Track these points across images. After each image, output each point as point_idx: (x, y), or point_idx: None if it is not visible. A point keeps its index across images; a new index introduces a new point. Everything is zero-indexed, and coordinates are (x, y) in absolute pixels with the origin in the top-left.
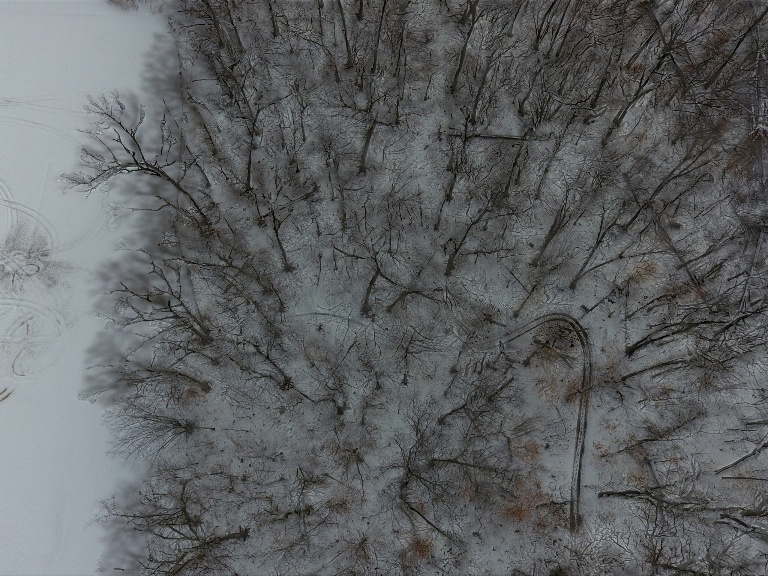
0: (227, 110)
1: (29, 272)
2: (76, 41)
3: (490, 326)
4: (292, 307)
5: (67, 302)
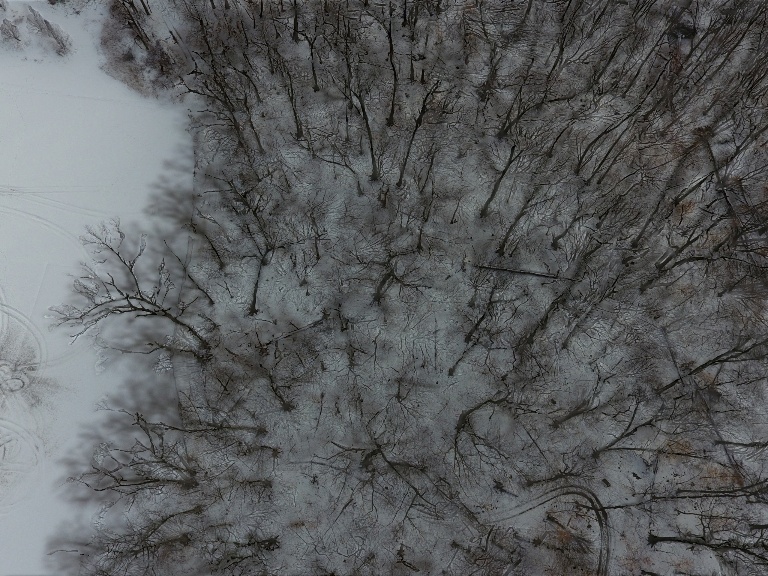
0: (239, 218)
1: (13, 387)
2: (90, 128)
3: (500, 495)
4: (286, 452)
5: (49, 426)
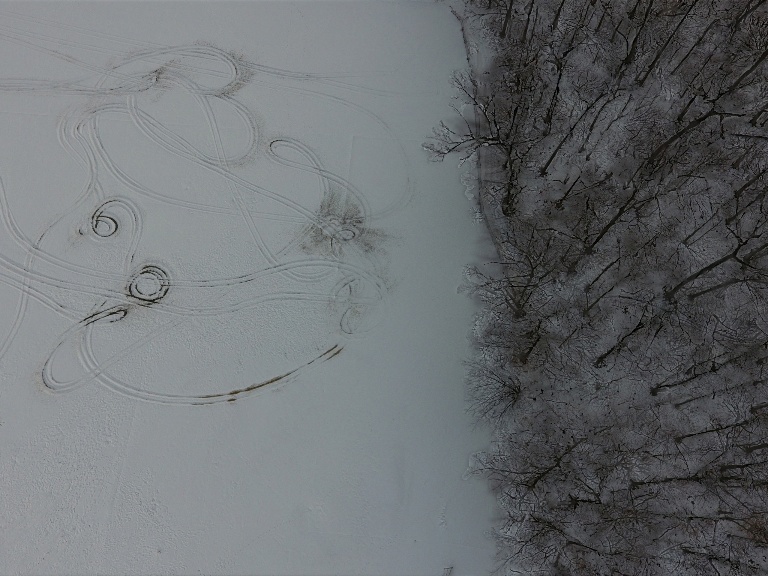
0: (515, 97)
1: (346, 237)
2: (366, 23)
3: None
4: (596, 289)
5: (385, 268)
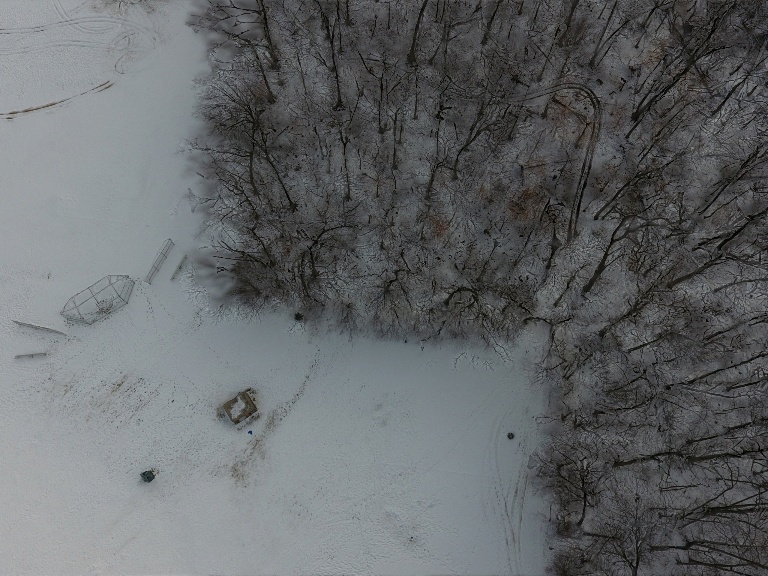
0: None
1: (133, 1)
2: None
3: (516, 85)
4: (348, 52)
5: (163, 25)
